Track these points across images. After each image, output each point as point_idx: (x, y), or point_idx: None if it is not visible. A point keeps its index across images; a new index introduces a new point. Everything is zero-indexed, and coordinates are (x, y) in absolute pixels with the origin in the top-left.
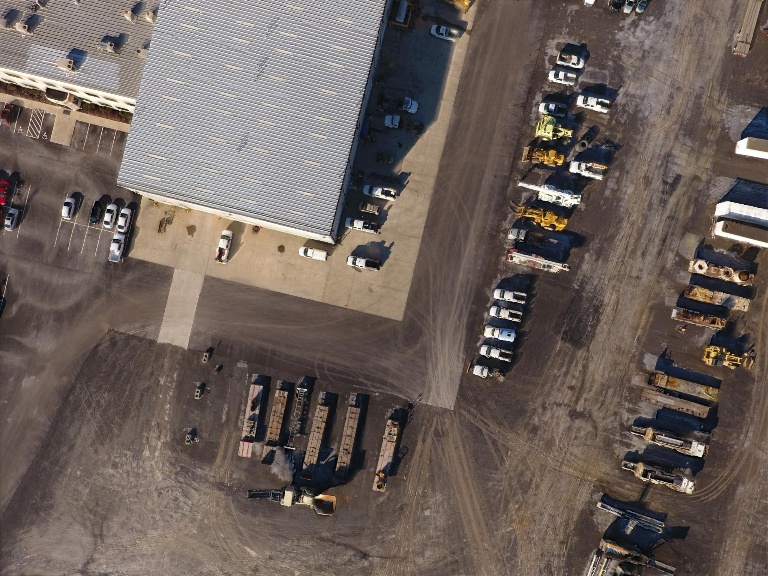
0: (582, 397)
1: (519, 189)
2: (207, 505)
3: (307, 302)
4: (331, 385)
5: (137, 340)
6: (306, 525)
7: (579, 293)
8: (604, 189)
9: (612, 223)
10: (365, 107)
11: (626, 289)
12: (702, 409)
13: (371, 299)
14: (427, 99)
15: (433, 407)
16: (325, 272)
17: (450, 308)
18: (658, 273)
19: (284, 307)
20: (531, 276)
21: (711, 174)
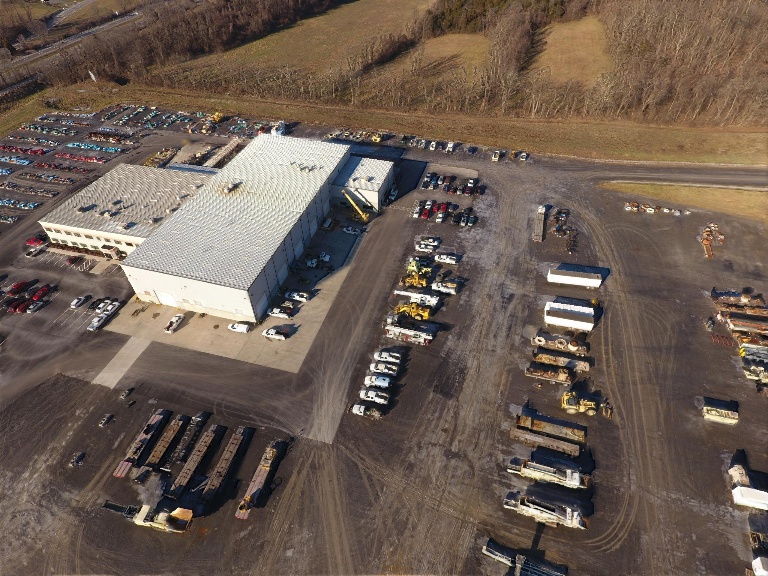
0: (456, 439)
1: (397, 299)
2: (55, 532)
3: (224, 359)
4: (224, 419)
5: (76, 381)
6: (150, 562)
7: (446, 360)
8: (459, 300)
9: (467, 318)
10: (294, 253)
11: (485, 358)
12: (572, 447)
13: (275, 358)
14: (337, 257)
15: (313, 441)
16: (244, 341)
17: (338, 366)
18: (509, 348)
19: (204, 362)
20: (406, 347)
21: (536, 294)
